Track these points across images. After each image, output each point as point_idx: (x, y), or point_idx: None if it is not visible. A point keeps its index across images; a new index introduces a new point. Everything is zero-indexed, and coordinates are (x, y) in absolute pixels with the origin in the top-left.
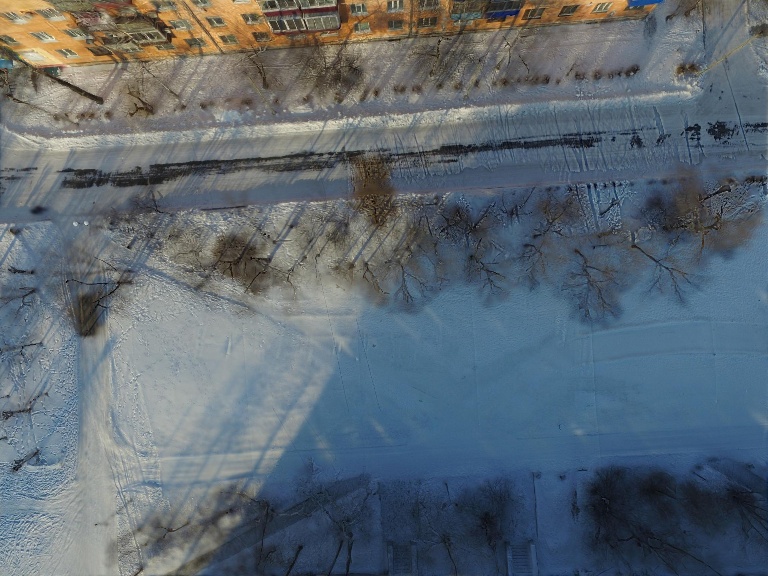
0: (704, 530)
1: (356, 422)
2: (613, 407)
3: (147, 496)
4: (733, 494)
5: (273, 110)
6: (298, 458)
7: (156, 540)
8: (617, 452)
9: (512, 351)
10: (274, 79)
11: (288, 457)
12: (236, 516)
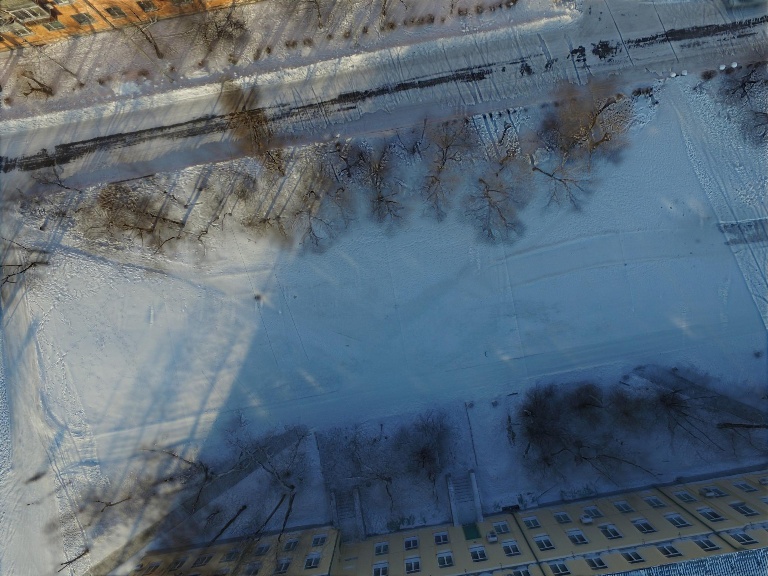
0: (634, 435)
1: (286, 374)
2: (535, 328)
3: (85, 476)
4: (659, 397)
5: (169, 77)
6: (233, 418)
7: (99, 519)
8: (544, 372)
9: (430, 285)
10: (168, 48)
11: (223, 418)
12: (177, 484)
